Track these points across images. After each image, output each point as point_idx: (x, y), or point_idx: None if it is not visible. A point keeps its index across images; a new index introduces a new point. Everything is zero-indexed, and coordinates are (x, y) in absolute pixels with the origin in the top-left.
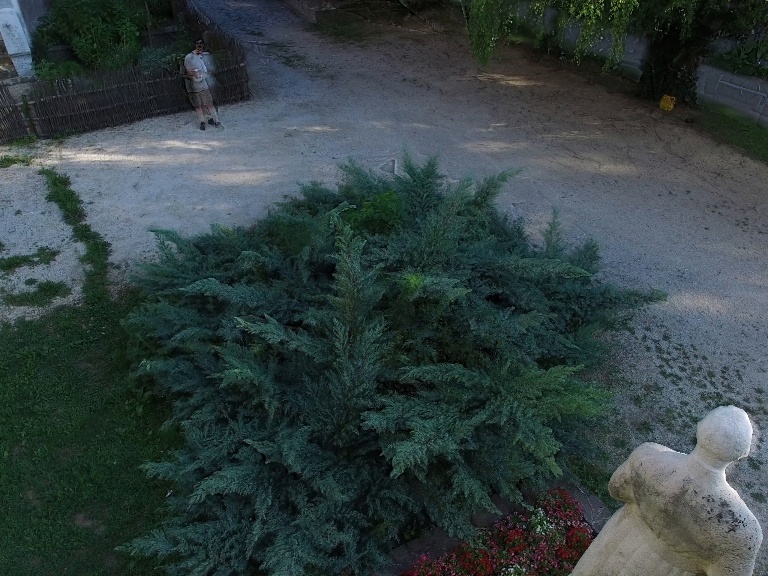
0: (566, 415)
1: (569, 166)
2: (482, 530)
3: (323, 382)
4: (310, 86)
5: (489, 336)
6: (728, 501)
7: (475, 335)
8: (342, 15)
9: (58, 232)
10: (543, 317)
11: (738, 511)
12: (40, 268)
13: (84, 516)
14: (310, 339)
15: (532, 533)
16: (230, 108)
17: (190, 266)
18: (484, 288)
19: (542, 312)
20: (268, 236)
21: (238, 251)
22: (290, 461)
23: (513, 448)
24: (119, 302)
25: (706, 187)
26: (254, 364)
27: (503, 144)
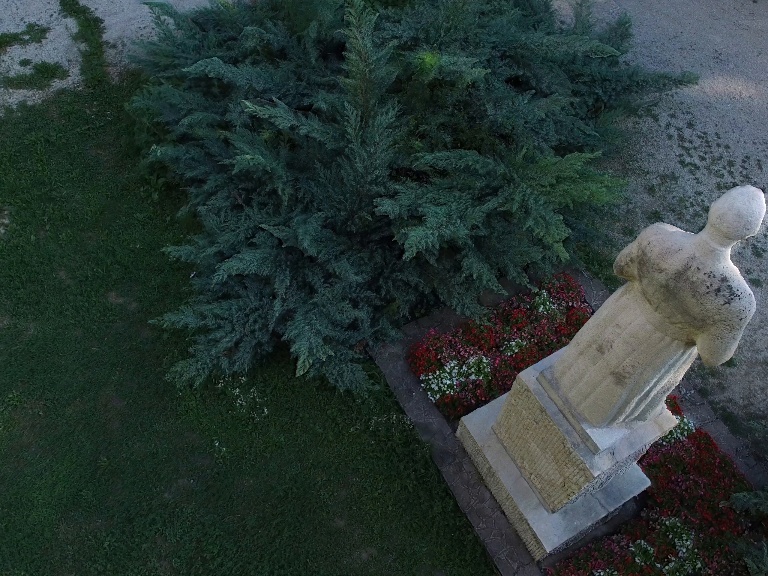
0: (578, 203)
1: None
2: (488, 309)
3: (335, 169)
4: None
5: (506, 121)
6: (728, 277)
7: (491, 120)
8: None
9: (44, 6)
10: (564, 101)
11: (736, 286)
12: (32, 47)
13: (116, 294)
14: (321, 124)
15: (535, 312)
16: None
17: (190, 44)
18: (504, 69)
19: (563, 96)
20: (271, 10)
21: (240, 27)
22: (306, 245)
23: (523, 234)
24: (120, 85)
25: None
26: (265, 150)
27: None
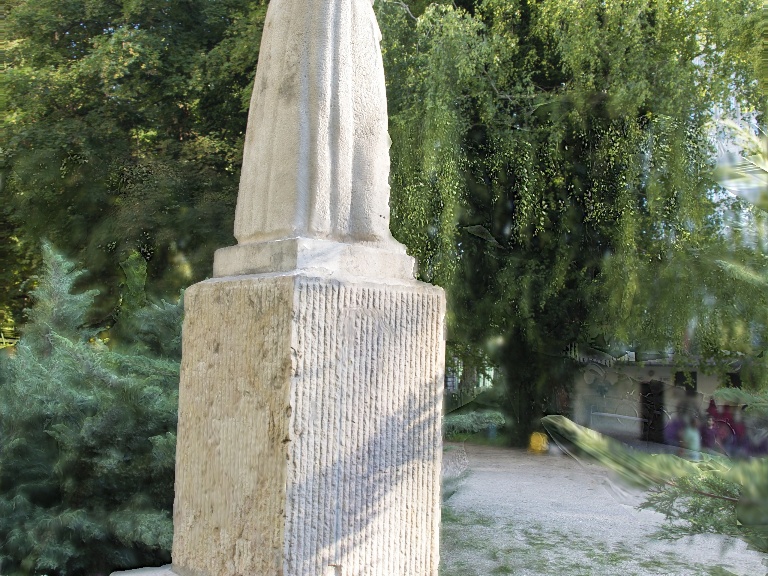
0: None
1: None
2: None
3: None
4: None
5: None
6: None
7: None
8: None
9: None
10: None
11: None
12: None
13: None
14: None
15: None
16: None
17: None
18: None
19: None
20: None
21: None
22: None
23: None
24: None
25: None
26: None
27: None
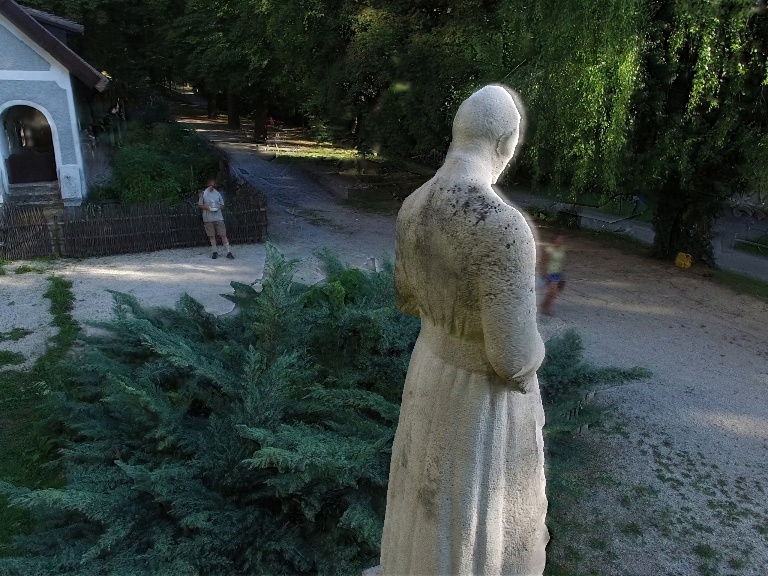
0: None
1: (574, 302)
2: None
3: (229, 419)
4: (328, 238)
5: None
6: (478, 188)
7: None
8: (373, 194)
9: (40, 319)
10: None
11: (490, 198)
12: (7, 343)
13: None
14: (224, 371)
15: None
16: (246, 246)
17: None
18: None
19: None
20: None
21: None
22: (153, 477)
23: None
24: None
25: (723, 324)
26: (163, 402)
27: None
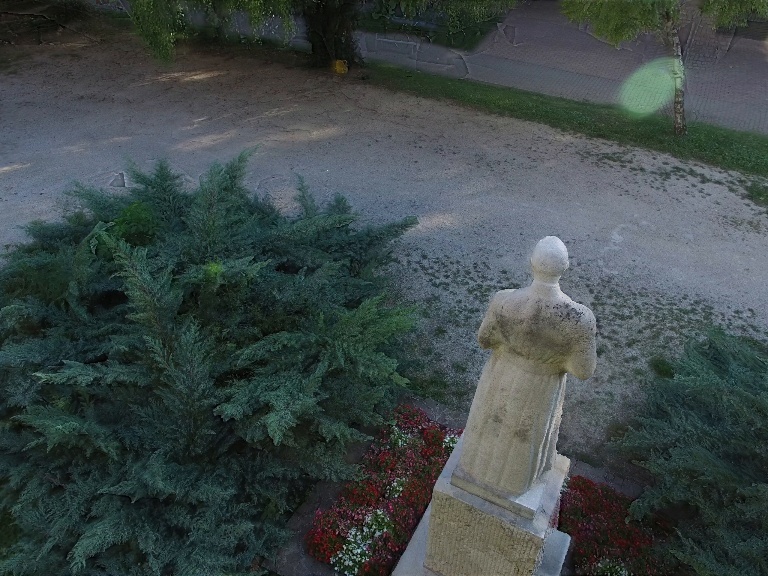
0: (381, 344)
1: (284, 141)
2: None
3: (155, 403)
4: None
5: (299, 297)
6: (569, 303)
7: (283, 303)
8: None
9: None
10: (337, 264)
11: (577, 307)
12: None
13: None
14: (124, 367)
15: (397, 448)
16: None
17: None
18: None
19: None
20: (7, 293)
21: None
22: (161, 486)
23: (359, 382)
24: None
25: (401, 129)
26: (68, 418)
27: (215, 136)
